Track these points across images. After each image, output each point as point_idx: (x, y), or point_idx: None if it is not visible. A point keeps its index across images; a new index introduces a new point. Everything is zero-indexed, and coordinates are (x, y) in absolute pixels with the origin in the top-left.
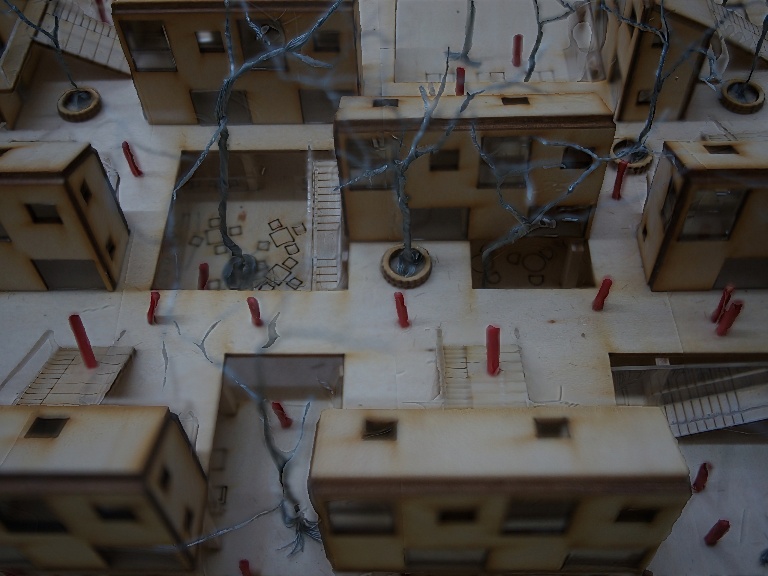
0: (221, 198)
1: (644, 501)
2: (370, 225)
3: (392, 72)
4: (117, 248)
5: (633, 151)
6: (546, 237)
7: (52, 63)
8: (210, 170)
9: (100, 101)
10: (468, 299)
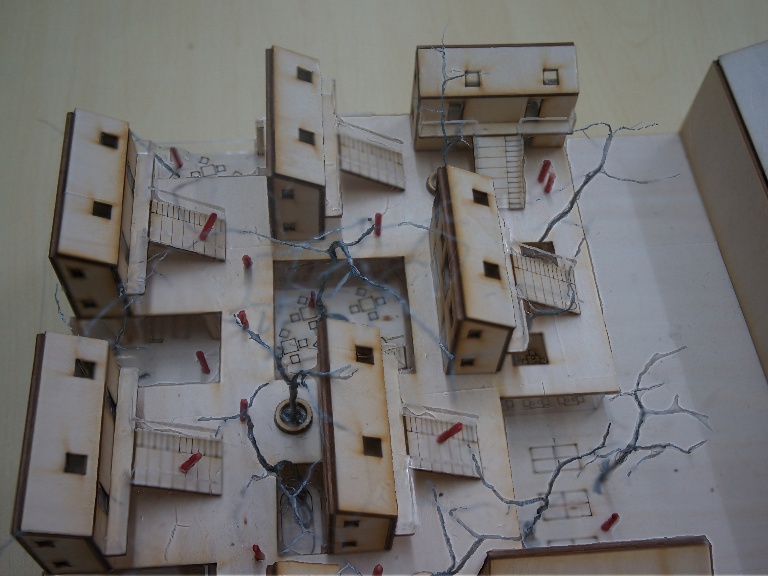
0: None
1: None
2: None
3: (512, 394)
4: (296, 232)
5: None
6: None
7: None
8: None
9: None
10: None
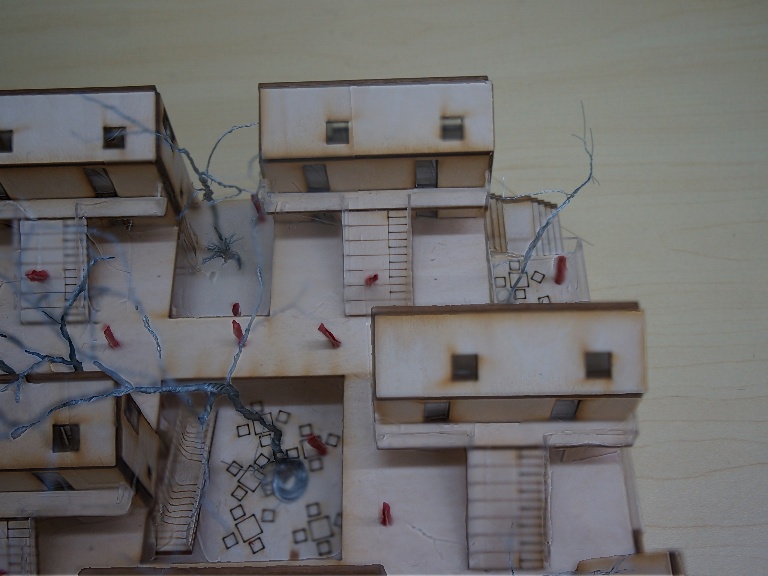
0: None
1: None
2: None
3: None
4: None
5: None
6: None
7: None
8: None
9: None
10: None
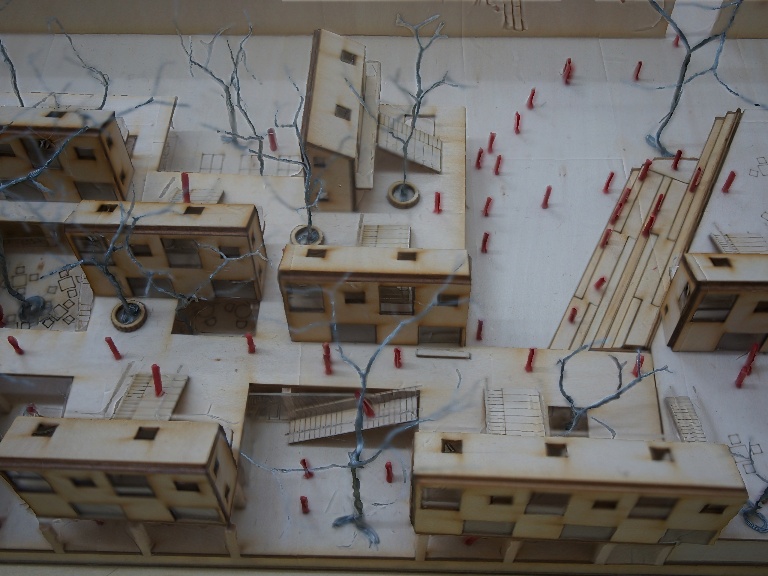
0: (27, 251)
1: (181, 478)
2: (105, 286)
3: (157, 163)
4: None
5: (251, 254)
6: (233, 298)
7: None
8: (15, 233)
9: None
10: (166, 341)
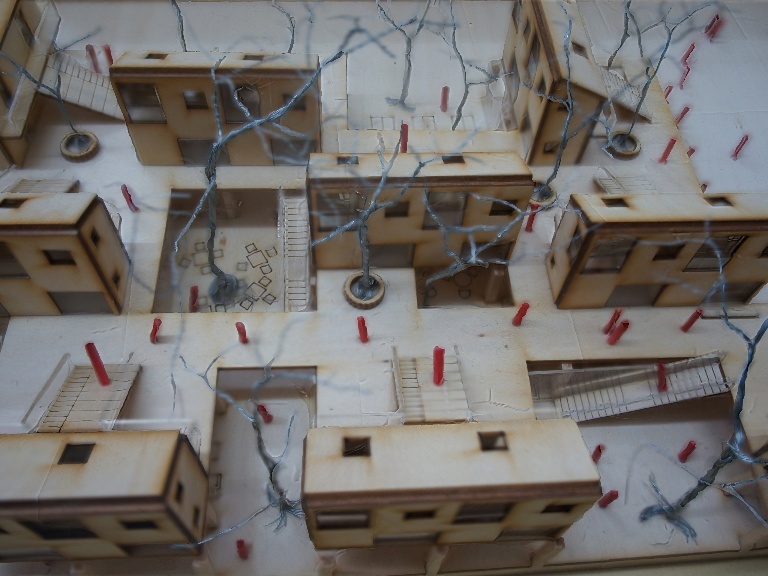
0: (204, 225)
1: (566, 501)
2: (334, 257)
3: (346, 121)
4: (121, 278)
5: None
6: None
7: (54, 110)
8: (195, 204)
9: (98, 144)
10: (415, 317)
